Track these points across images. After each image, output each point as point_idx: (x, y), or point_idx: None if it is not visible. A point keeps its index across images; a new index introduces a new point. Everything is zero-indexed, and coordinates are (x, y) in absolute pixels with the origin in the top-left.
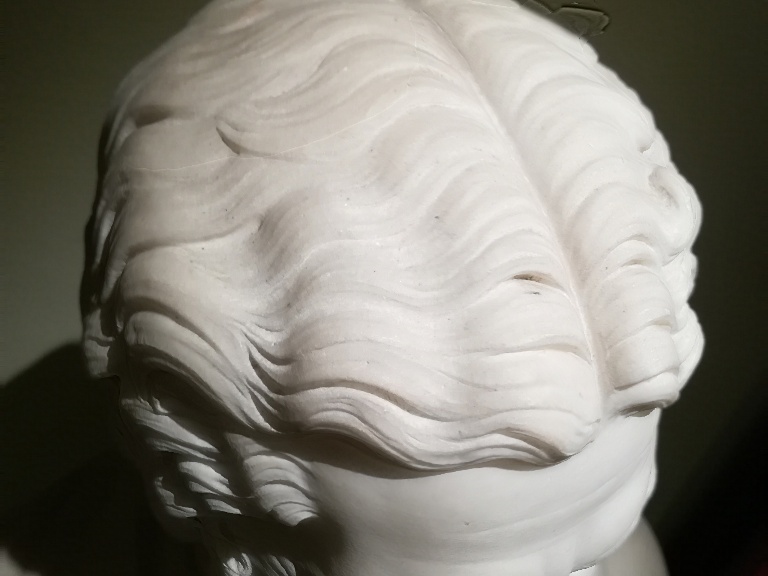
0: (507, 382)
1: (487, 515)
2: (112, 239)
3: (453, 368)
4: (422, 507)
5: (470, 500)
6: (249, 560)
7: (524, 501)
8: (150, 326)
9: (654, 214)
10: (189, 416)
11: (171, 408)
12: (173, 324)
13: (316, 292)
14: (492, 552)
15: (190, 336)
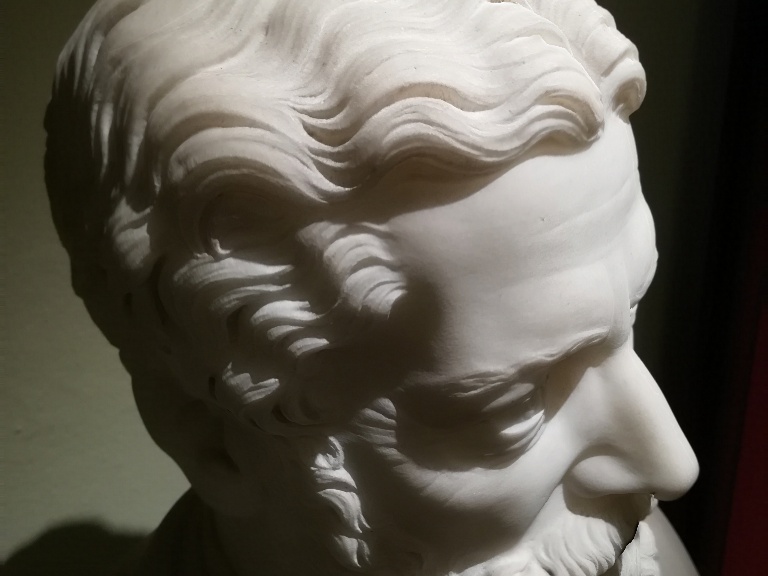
0: (529, 54)
1: (555, 206)
2: (120, 119)
3: (482, 62)
4: (501, 214)
5: (537, 193)
6: (338, 442)
7: (577, 190)
8: (197, 145)
9: None
10: (253, 244)
11: (232, 245)
12: (220, 130)
13: (345, 41)
14: (569, 256)
15: (241, 131)
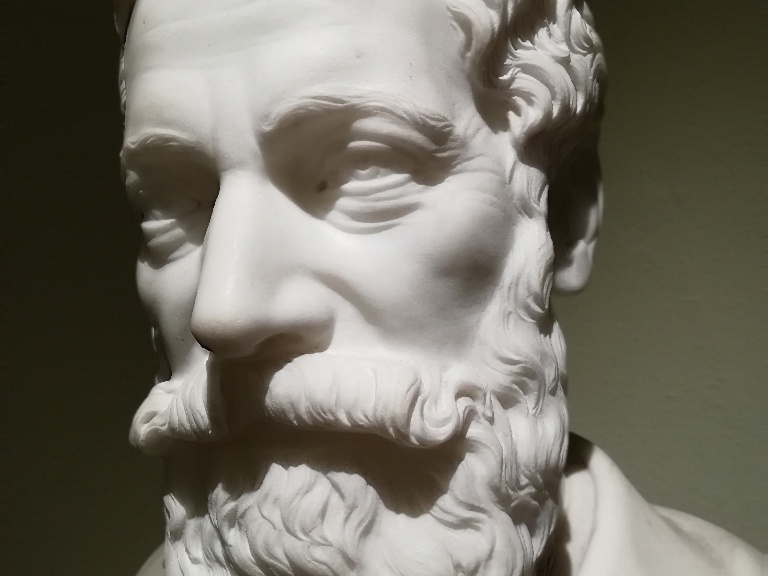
0: None
1: None
2: None
3: None
4: None
5: None
6: None
7: None
8: None
9: None
10: None
11: None
12: None
13: None
14: (161, 57)
15: None
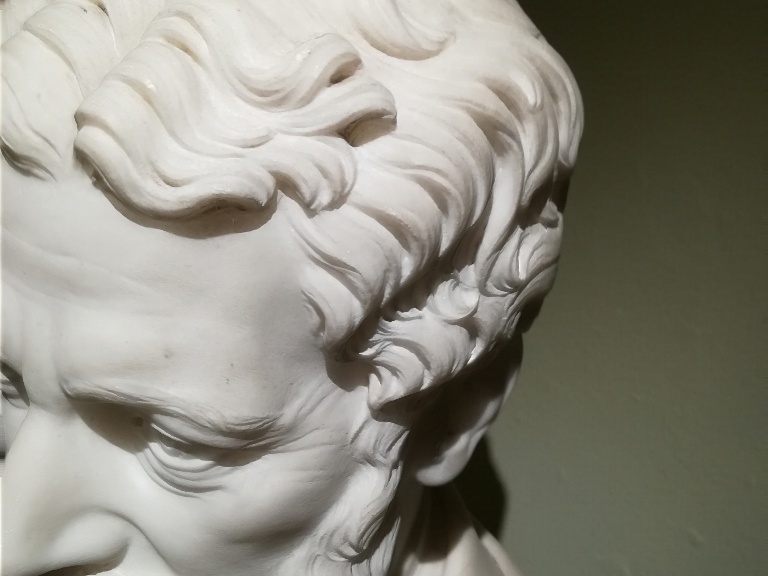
0: None
1: None
2: None
3: None
4: None
5: None
6: None
7: (3, 199)
8: None
9: (240, 26)
10: None
11: None
12: None
13: None
14: None
15: None
